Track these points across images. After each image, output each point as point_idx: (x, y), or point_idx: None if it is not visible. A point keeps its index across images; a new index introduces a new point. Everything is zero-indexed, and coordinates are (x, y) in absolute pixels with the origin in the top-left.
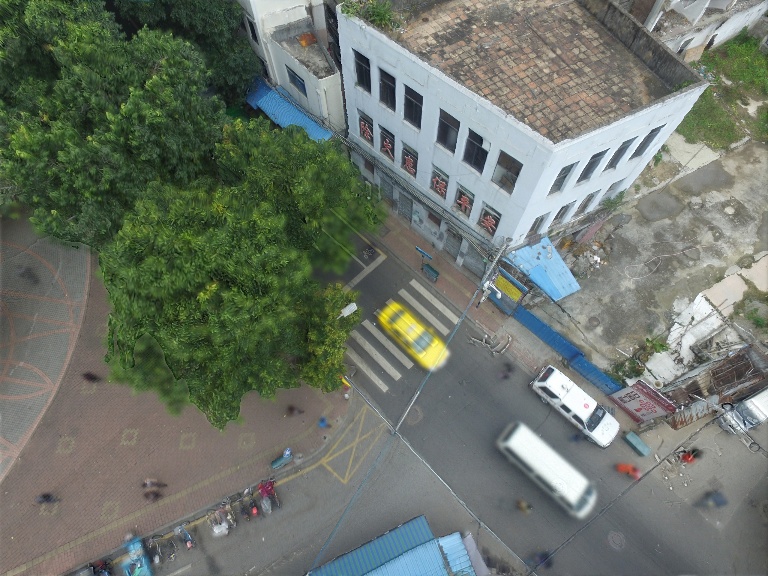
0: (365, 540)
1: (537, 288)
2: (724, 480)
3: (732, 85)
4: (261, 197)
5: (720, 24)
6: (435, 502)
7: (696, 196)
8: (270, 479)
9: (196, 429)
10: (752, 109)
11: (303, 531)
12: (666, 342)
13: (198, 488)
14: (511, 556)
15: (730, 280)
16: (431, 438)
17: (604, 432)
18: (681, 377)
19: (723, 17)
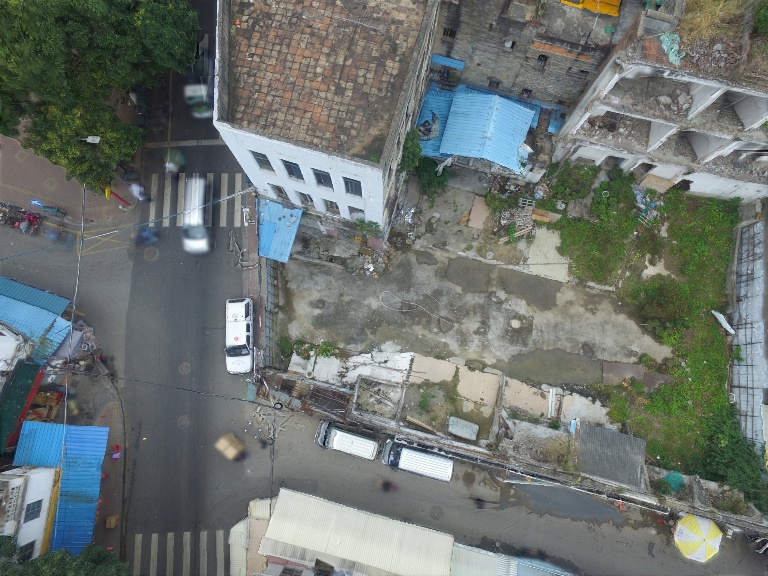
0: (59, 293)
1: (257, 237)
2: (281, 457)
3: (664, 238)
4: (2, 6)
5: (688, 171)
6: (113, 310)
7: (506, 292)
8: (44, 216)
9: (31, 152)
10: (651, 271)
11: (34, 259)
12: (348, 358)
13: (4, 186)
14: (122, 374)
15: (446, 364)
16: (147, 276)
17: (234, 363)
18: (325, 383)
19: (689, 166)
